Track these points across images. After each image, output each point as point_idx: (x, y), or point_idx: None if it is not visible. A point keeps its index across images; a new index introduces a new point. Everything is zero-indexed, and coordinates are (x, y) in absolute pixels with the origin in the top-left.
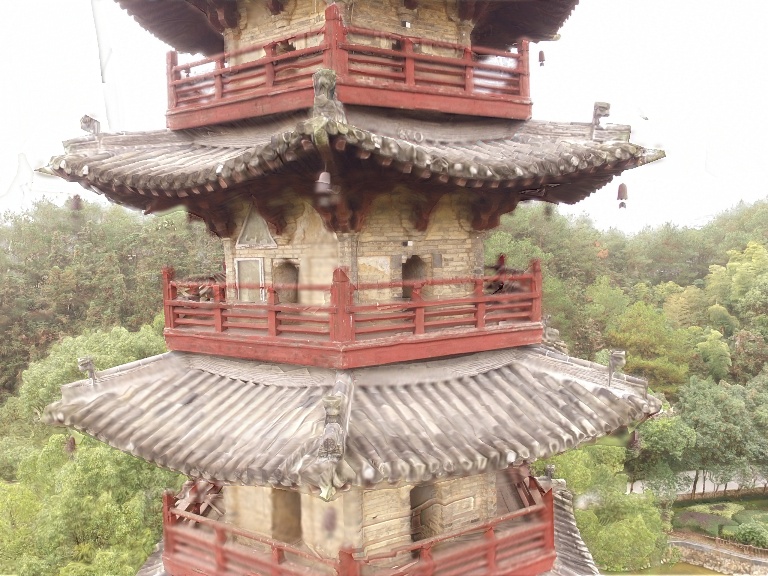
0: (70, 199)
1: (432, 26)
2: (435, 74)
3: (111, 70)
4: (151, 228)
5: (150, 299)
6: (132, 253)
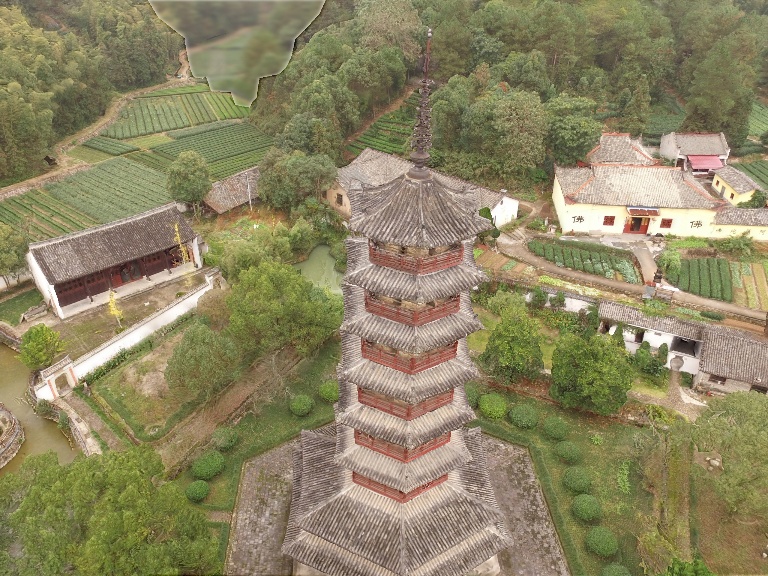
0: None
1: None
2: None
3: None
4: None
5: None
6: None
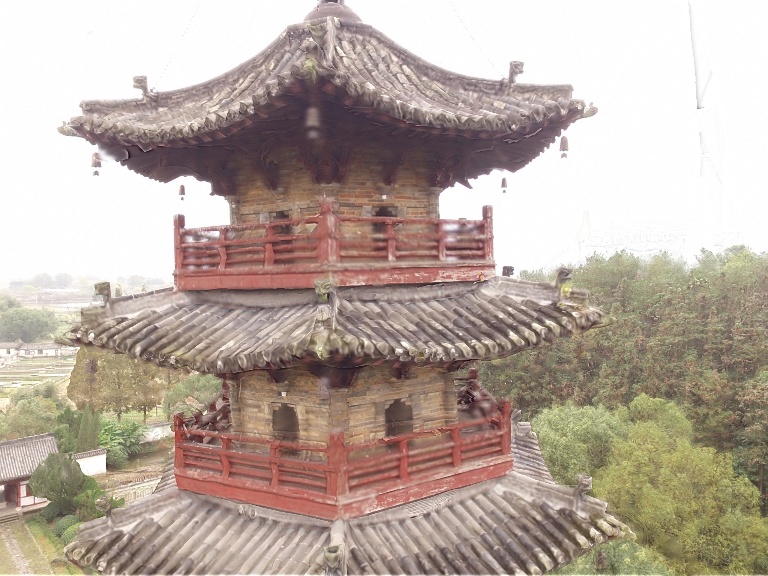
0: (616, 254)
1: (307, 392)
2: (247, 467)
3: (711, 93)
4: (681, 287)
5: (655, 369)
6: (655, 314)
